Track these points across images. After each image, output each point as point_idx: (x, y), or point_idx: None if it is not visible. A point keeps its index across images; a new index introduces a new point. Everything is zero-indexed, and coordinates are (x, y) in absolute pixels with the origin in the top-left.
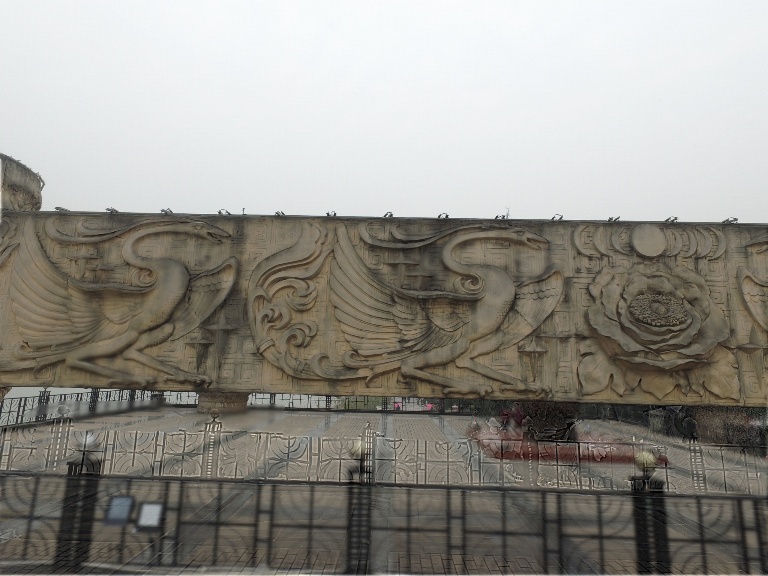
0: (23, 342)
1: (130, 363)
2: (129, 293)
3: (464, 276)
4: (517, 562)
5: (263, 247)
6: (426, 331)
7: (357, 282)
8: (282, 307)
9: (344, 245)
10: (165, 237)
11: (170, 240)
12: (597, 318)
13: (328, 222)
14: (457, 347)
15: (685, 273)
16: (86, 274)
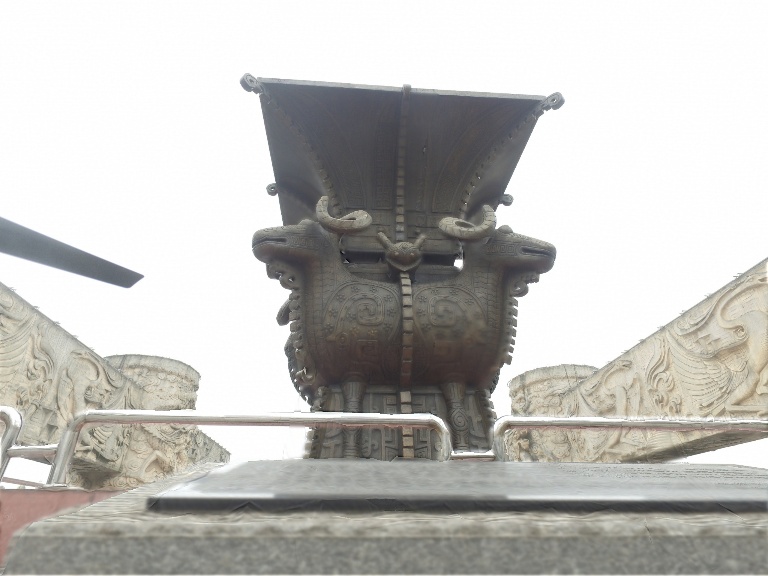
0: (593, 445)
1: (624, 445)
2: (609, 409)
3: (737, 328)
4: None
5: (645, 362)
6: (729, 377)
7: (685, 361)
8: (662, 392)
9: (671, 342)
10: (613, 375)
11: (615, 376)
12: None
13: (662, 332)
14: (749, 381)
15: None
16: (599, 406)
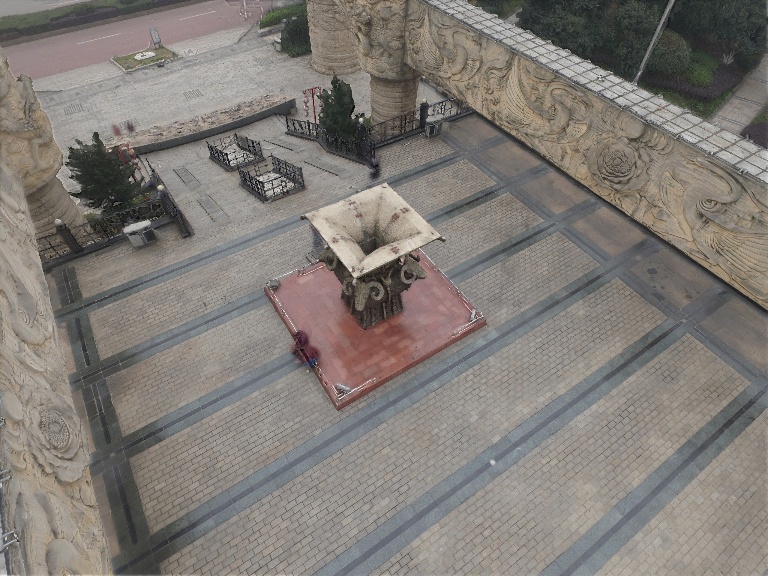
0: None
1: None
2: None
3: None
4: (172, 571)
5: None
6: None
7: None
8: None
9: None
10: None
11: None
12: (69, 475)
13: None
14: None
15: (25, 394)
16: None
